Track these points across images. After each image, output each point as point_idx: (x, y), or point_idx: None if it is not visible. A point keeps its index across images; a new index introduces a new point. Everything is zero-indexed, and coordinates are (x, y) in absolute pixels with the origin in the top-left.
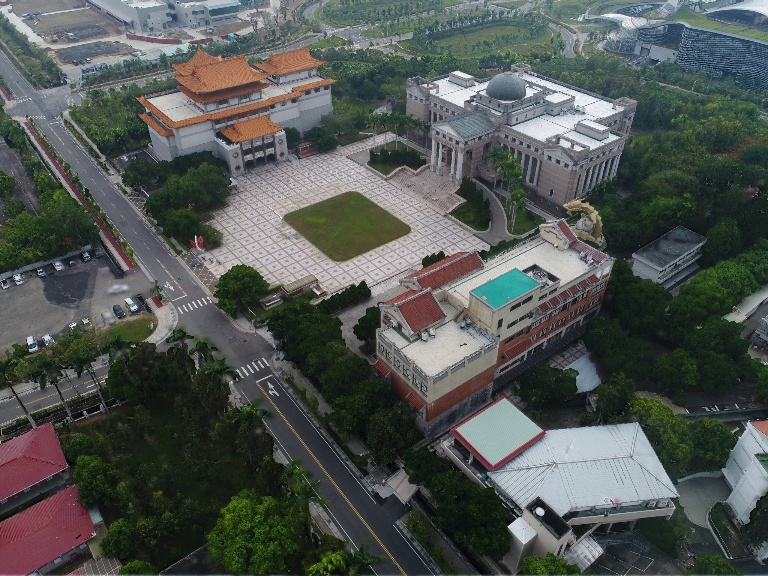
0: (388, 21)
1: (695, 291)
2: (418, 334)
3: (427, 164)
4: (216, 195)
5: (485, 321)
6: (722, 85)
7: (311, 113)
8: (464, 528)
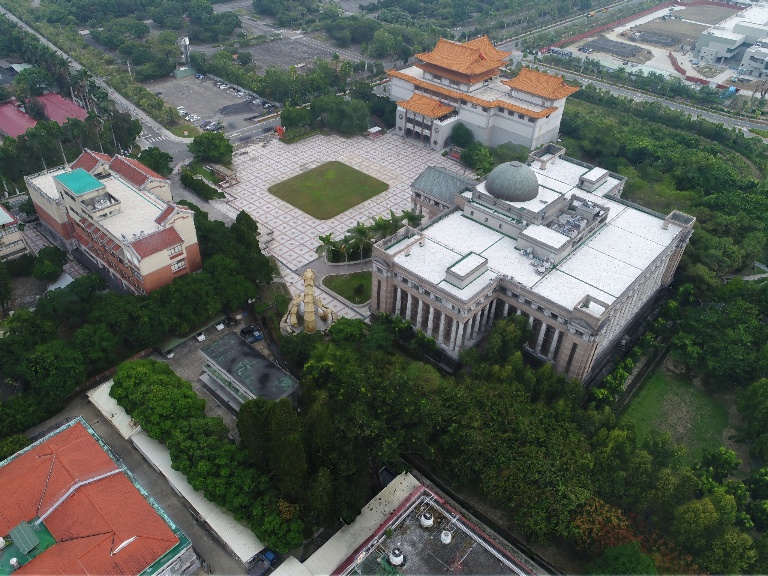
0: None
1: None
2: None
3: None
4: None
5: None
6: None
7: (509, 135)
8: None
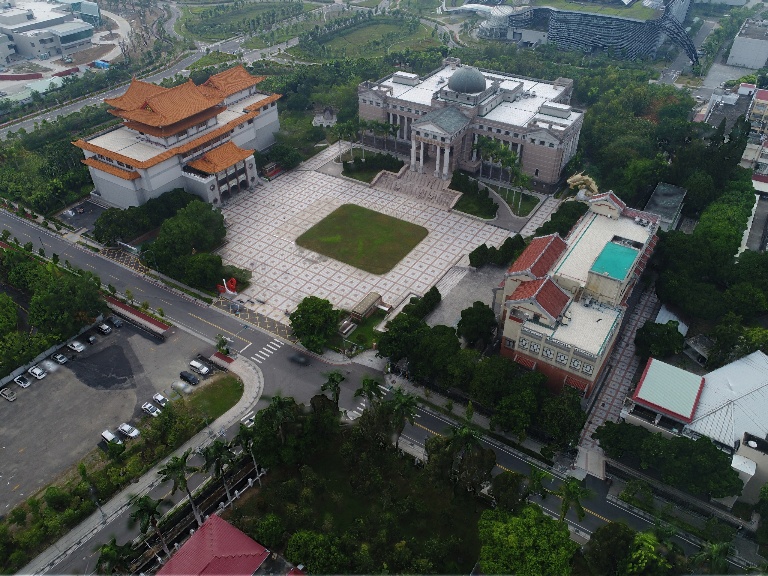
0: (263, 31)
1: (712, 234)
2: (556, 320)
3: (405, 165)
4: (217, 233)
5: (608, 294)
6: (600, 58)
7: (262, 132)
8: (692, 480)
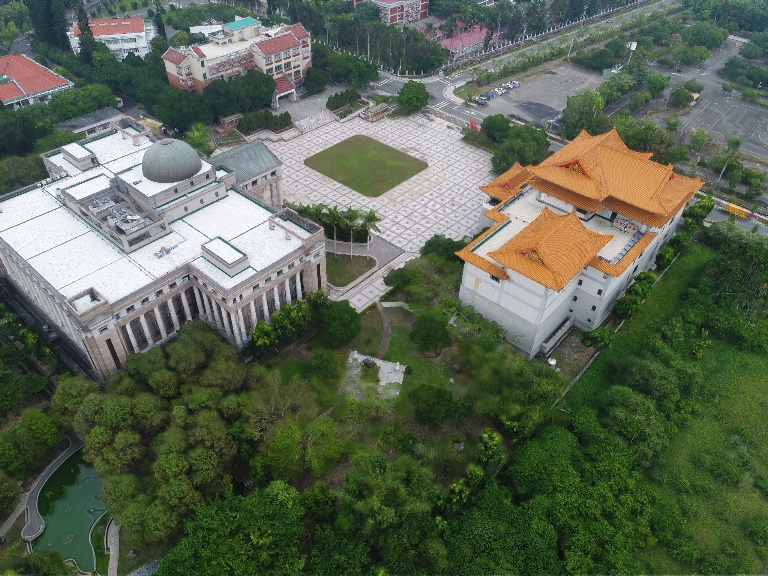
0: None
1: None
2: None
3: None
4: None
5: None
6: None
7: None
8: None
